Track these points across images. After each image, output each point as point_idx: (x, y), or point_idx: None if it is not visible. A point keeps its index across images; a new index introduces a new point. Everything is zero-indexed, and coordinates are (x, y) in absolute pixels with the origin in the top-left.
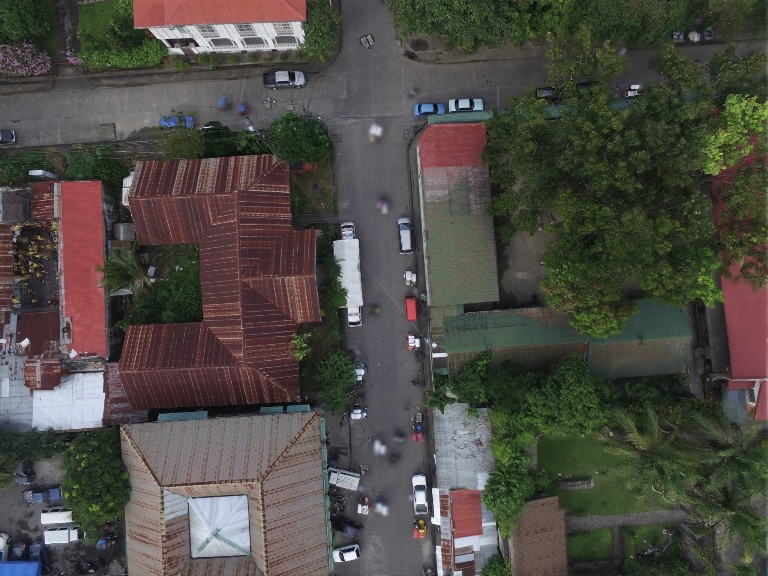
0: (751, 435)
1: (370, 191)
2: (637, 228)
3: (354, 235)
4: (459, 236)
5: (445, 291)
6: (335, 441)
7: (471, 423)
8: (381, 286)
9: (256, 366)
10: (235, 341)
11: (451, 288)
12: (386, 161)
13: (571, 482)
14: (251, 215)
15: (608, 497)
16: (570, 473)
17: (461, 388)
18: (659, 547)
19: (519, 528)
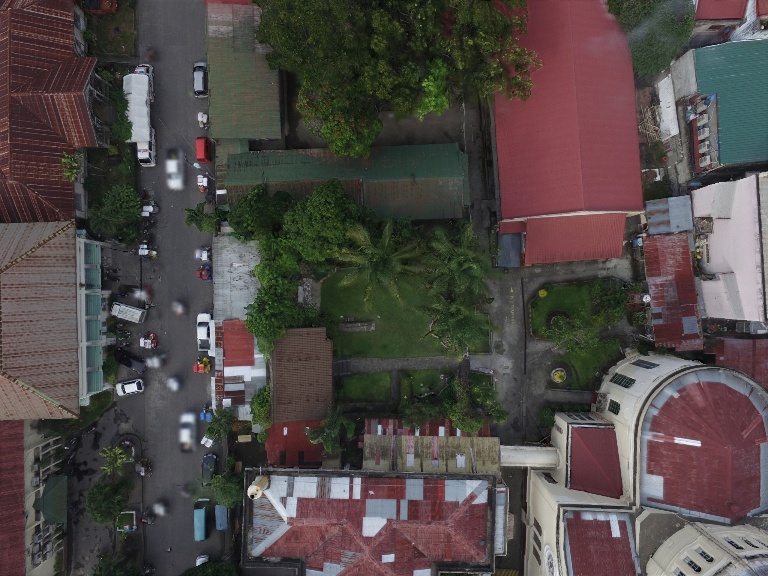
0: (468, 238)
1: (171, 36)
2: (335, 9)
3: (149, 75)
4: (242, 73)
5: (225, 125)
6: (125, 279)
7: (246, 255)
8: (177, 129)
9: (23, 181)
10: (4, 156)
11: (231, 122)
12: (188, 7)
13: (351, 324)
14: (25, 34)
15: (388, 341)
16: (352, 316)
17: (233, 217)
18: (436, 391)
19: (281, 353)
